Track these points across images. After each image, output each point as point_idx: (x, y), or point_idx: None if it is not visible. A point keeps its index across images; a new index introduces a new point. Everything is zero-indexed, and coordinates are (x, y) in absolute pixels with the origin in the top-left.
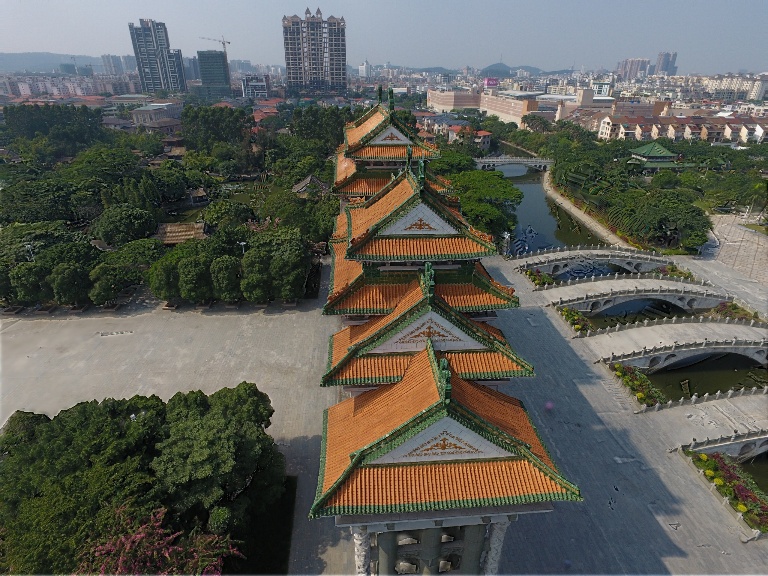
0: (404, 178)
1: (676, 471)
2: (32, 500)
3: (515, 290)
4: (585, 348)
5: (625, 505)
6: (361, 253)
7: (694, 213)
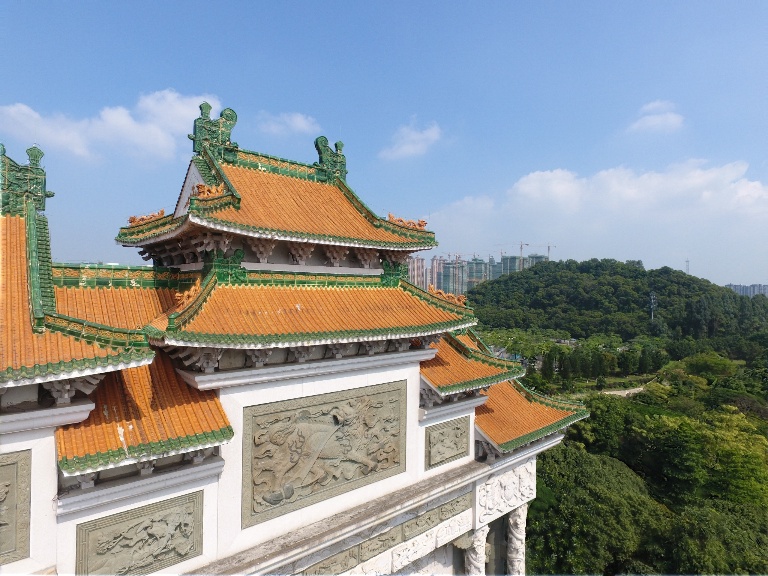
0: None
1: None
2: None
3: None
4: None
5: None
6: None
7: None
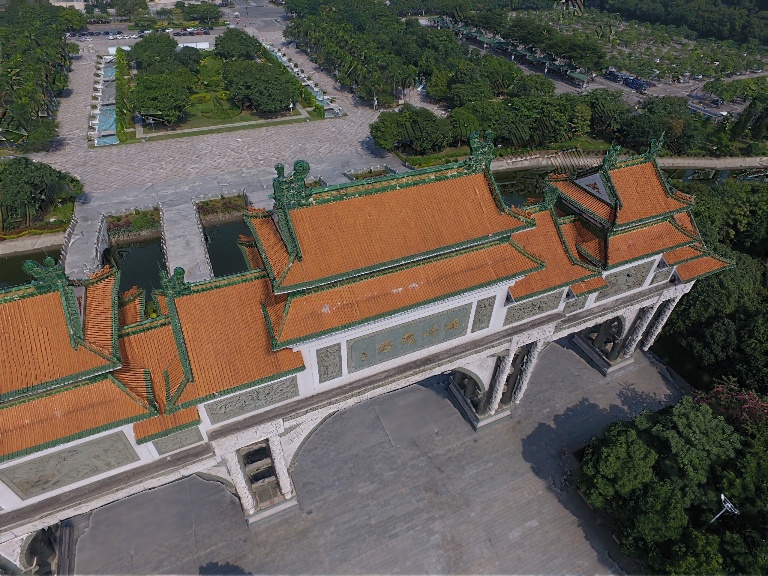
0: None
1: None
2: None
3: None
4: None
5: None
6: None
7: (30, 164)
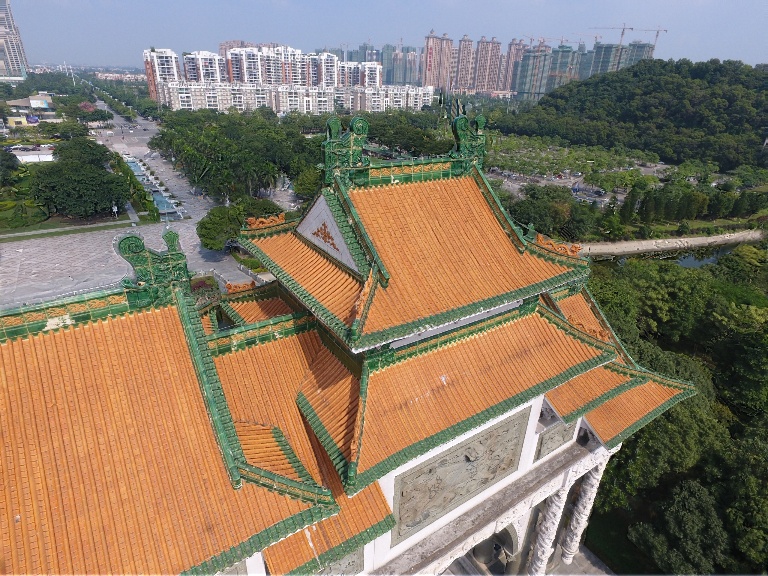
0: None
1: None
2: None
3: None
4: None
5: None
6: None
7: None
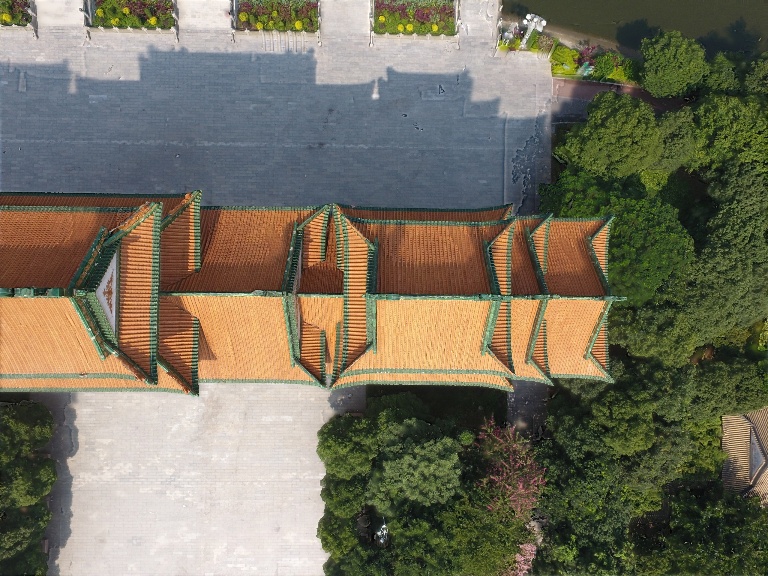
0: (376, 302)
1: (393, 54)
2: (476, 575)
3: (30, 64)
4: (201, 36)
5: (420, 117)
6: (507, 362)
7: None
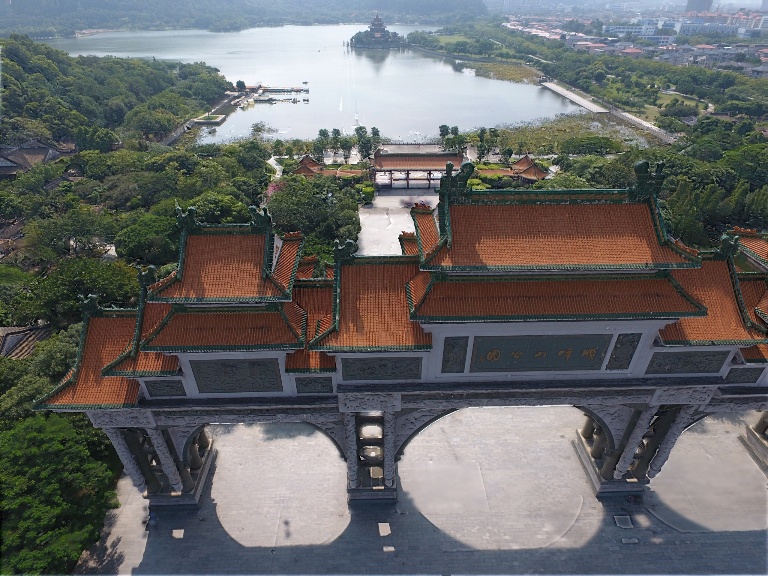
0: None
1: None
2: None
3: None
4: None
5: None
6: None
7: None
